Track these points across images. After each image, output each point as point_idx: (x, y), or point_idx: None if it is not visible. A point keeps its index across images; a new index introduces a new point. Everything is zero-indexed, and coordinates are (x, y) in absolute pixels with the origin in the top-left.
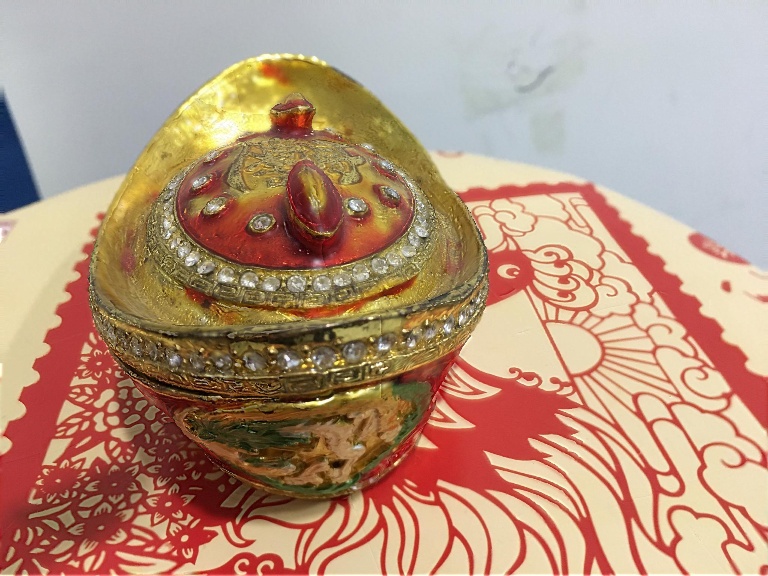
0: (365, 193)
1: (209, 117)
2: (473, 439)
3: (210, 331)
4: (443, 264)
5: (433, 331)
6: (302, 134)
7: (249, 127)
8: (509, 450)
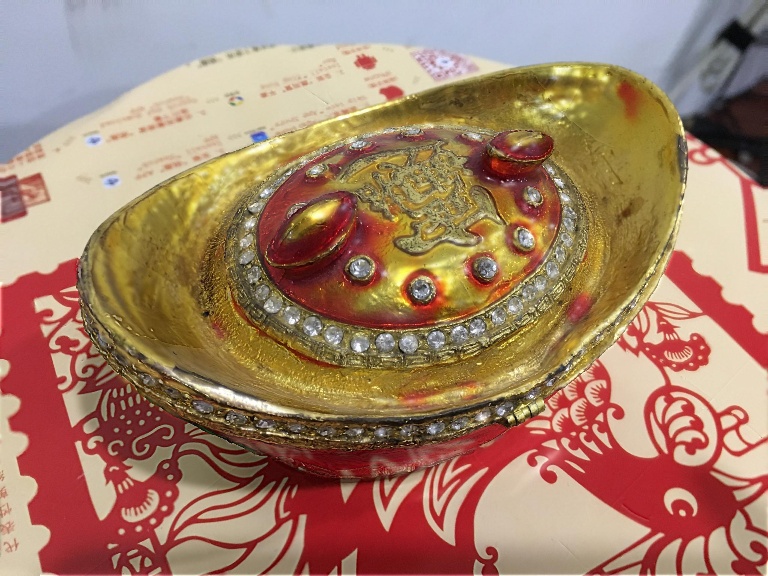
0: (399, 267)
1: (531, 96)
2: (369, 534)
3: (91, 239)
4: (406, 389)
5: (175, 394)
6: (487, 174)
7: (559, 131)
8: (367, 575)
